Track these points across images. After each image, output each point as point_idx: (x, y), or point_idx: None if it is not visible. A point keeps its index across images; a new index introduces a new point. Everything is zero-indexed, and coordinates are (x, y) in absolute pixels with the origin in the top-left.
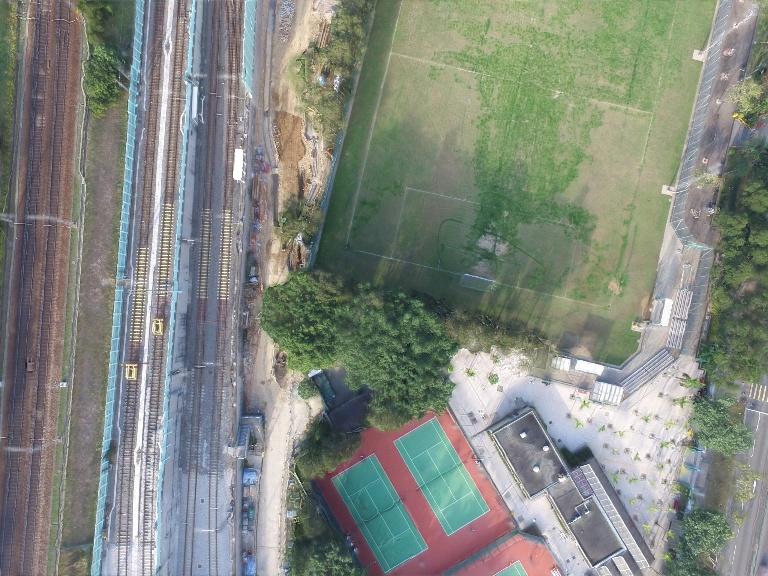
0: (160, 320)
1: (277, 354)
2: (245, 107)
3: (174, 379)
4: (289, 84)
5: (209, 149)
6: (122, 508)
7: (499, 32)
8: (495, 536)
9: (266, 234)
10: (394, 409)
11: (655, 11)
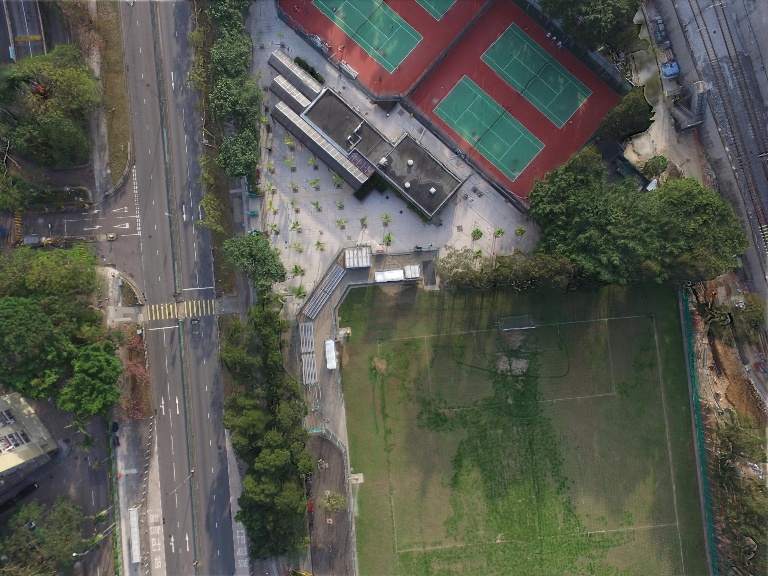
0: None
1: None
2: None
3: None
4: None
5: None
6: None
7: None
8: (421, 89)
9: None
10: None
11: None
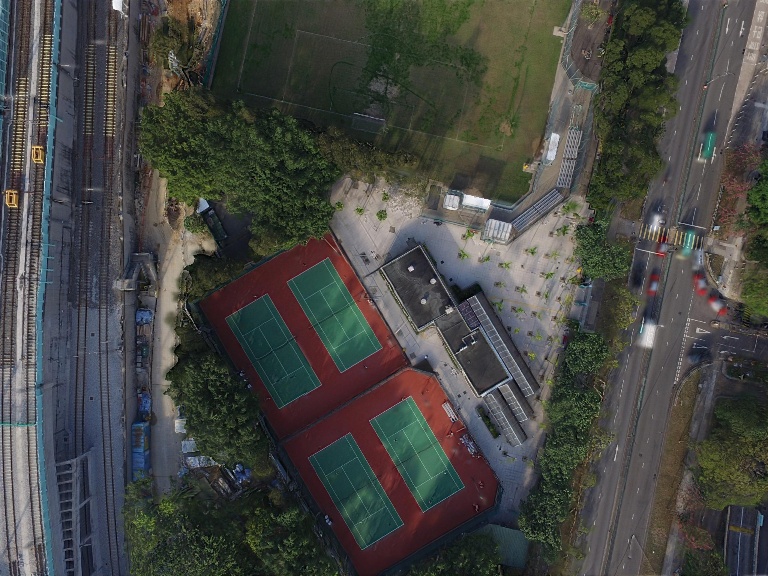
0: (40, 147)
1: (170, 197)
2: None
3: (56, 207)
4: None
5: None
6: (5, 332)
7: None
8: (387, 373)
9: (156, 77)
10: (270, 226)
11: None
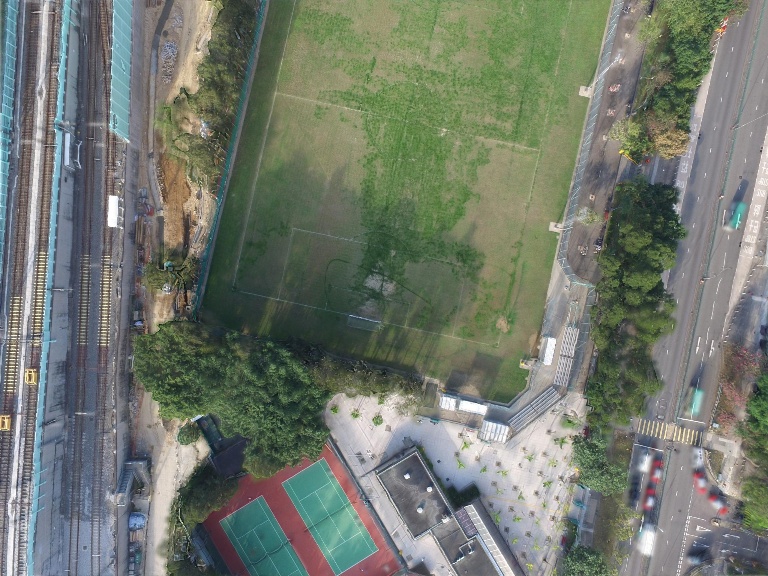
0: (33, 370)
1: None
2: (123, 152)
3: (49, 429)
4: (173, 125)
5: (87, 194)
6: None
7: (385, 70)
8: (384, 575)
9: None
10: (264, 458)
11: (541, 47)
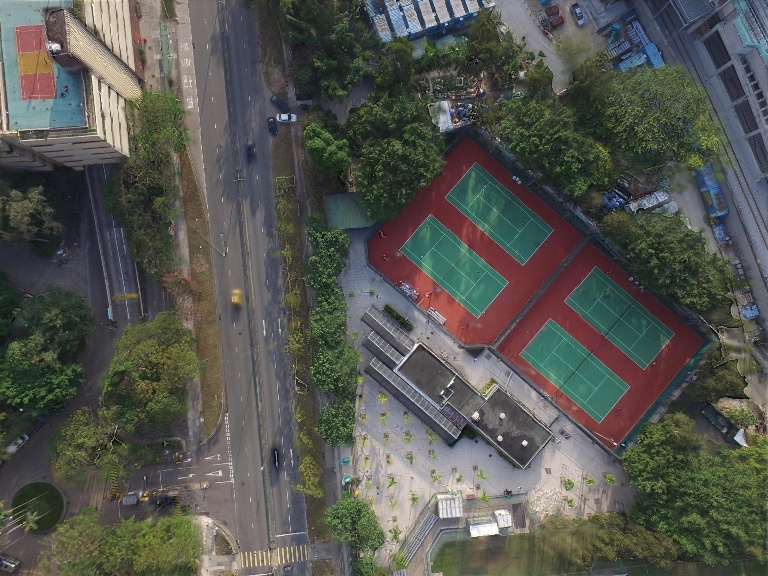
0: None
1: (766, 430)
2: None
3: None
4: None
5: None
6: None
7: None
8: None
9: None
10: None
11: None
